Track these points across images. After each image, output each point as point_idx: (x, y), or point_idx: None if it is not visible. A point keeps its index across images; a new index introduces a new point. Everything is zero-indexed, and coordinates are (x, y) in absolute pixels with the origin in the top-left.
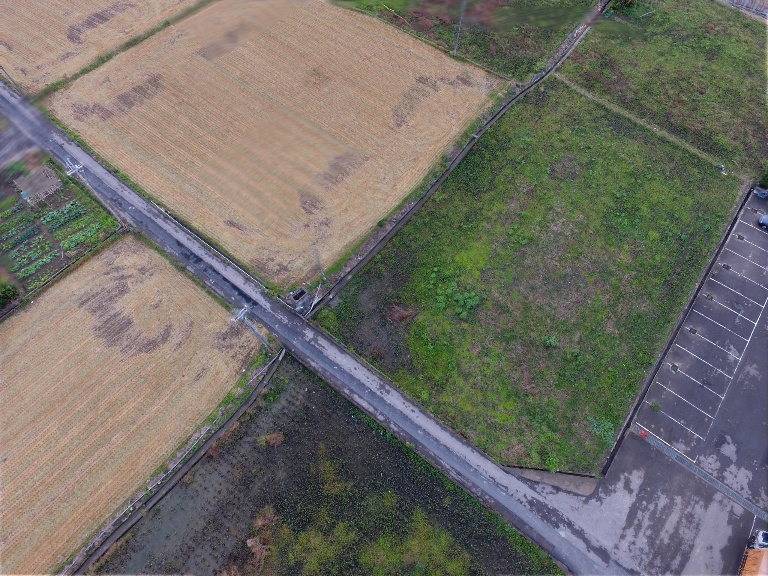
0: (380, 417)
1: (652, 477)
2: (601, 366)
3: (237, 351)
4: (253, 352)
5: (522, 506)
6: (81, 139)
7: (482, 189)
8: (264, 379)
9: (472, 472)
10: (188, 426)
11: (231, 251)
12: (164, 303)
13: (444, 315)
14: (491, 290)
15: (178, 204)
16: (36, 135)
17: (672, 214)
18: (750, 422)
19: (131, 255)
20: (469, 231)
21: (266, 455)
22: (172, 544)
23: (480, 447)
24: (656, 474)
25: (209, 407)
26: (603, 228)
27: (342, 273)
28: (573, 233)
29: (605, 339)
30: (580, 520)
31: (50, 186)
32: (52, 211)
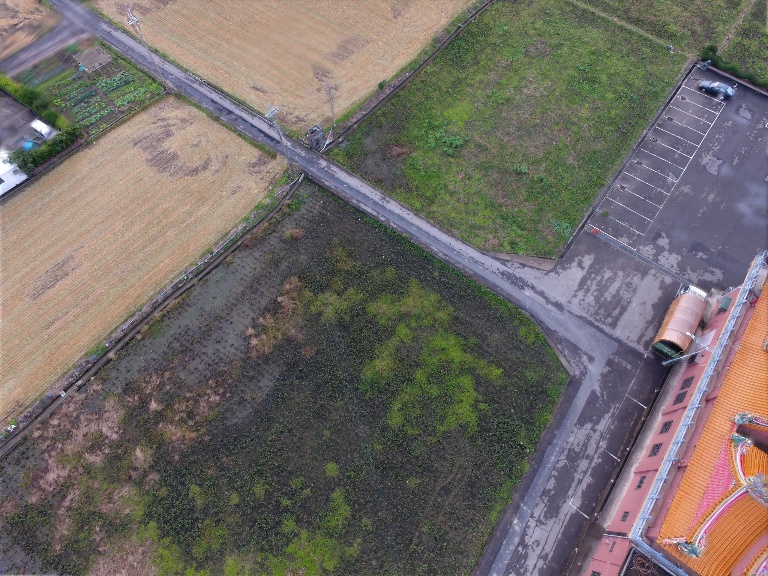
0: (382, 218)
1: (600, 259)
2: (562, 186)
3: (264, 175)
4: (278, 176)
5: (495, 275)
6: (125, 28)
7: (466, 64)
8: (287, 195)
9: (456, 254)
10: (227, 224)
11: (256, 108)
12: (203, 143)
13: (434, 152)
14: (473, 135)
15: (210, 75)
16: (87, 25)
17: (626, 81)
18: (682, 223)
19: (174, 110)
20: (455, 94)
21: (291, 245)
22: (218, 302)
23: (462, 239)
24: (604, 257)
25: (244, 212)
26: (568, 92)
27: (349, 123)
28: (542, 95)
29: (566, 168)
30: (541, 285)
31: (103, 59)
32: (105, 79)
